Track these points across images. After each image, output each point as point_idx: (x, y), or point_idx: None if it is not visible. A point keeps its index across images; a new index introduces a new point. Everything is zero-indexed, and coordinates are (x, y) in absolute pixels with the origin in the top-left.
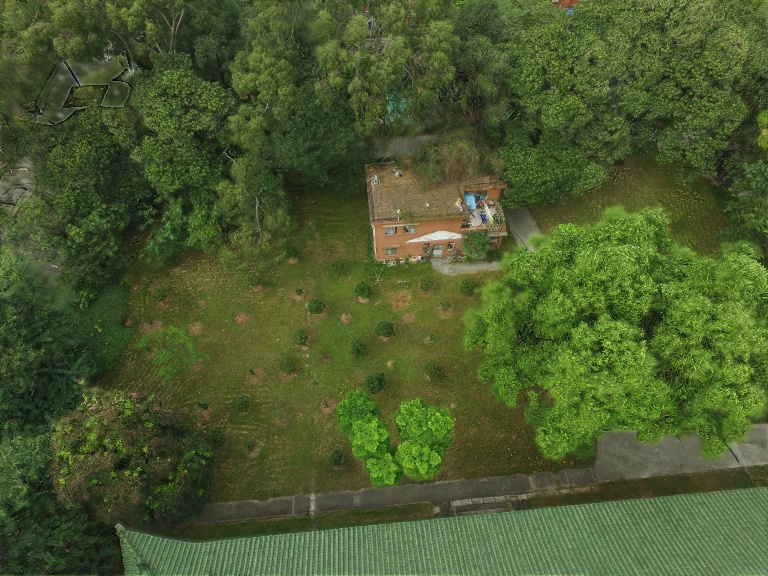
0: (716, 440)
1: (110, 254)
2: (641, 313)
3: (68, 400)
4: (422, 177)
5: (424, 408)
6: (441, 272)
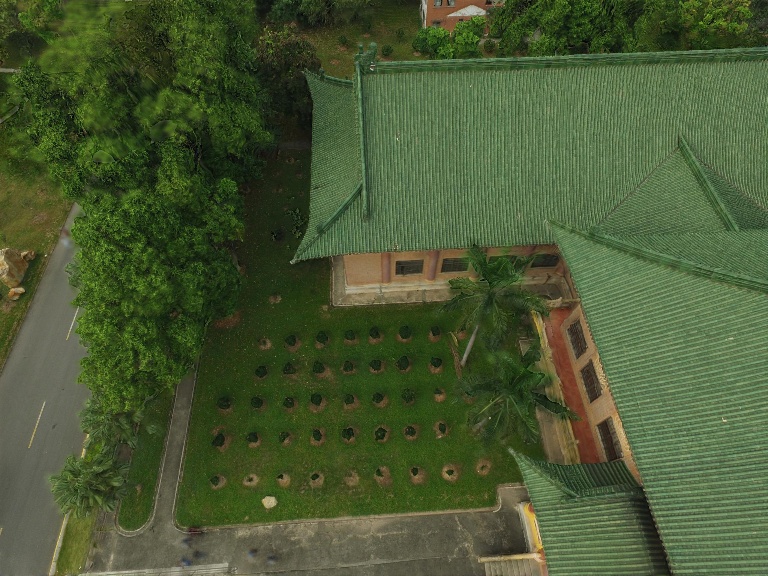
0: (631, 40)
1: (251, 9)
2: None
3: None
4: None
5: None
6: None
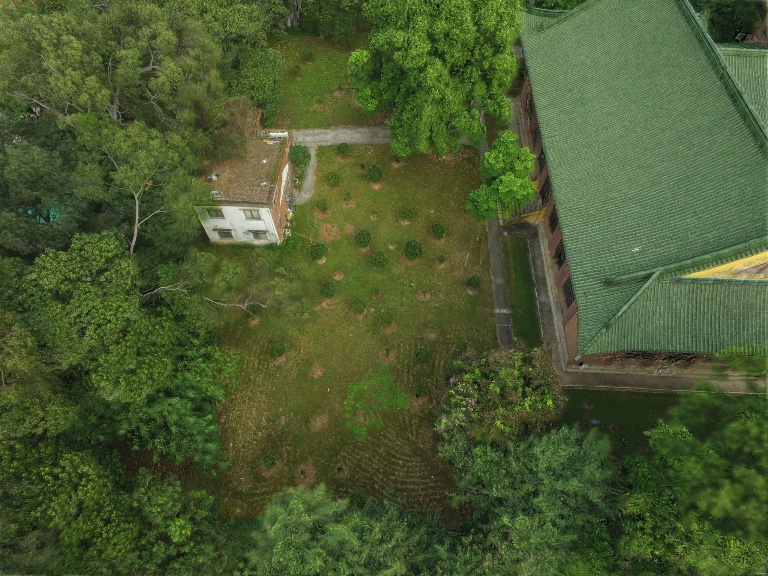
0: None
1: (212, 499)
2: (470, 6)
3: (413, 522)
4: (232, 156)
5: (492, 150)
6: (308, 200)
